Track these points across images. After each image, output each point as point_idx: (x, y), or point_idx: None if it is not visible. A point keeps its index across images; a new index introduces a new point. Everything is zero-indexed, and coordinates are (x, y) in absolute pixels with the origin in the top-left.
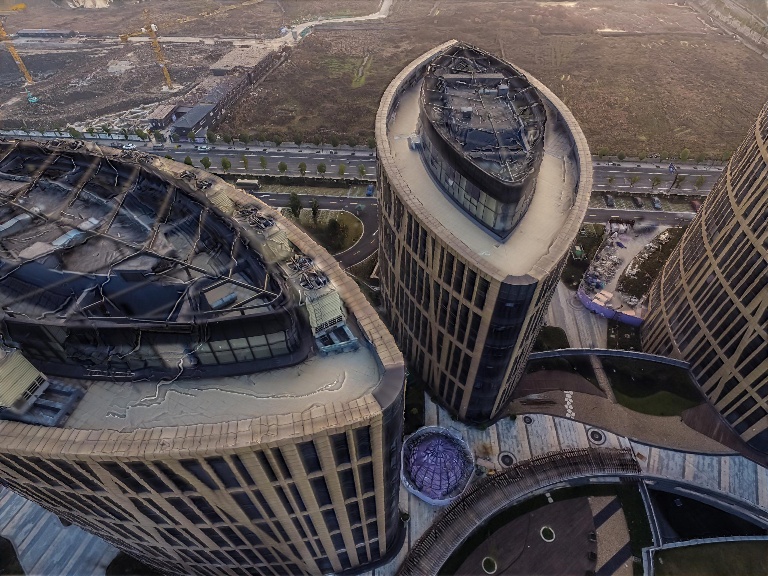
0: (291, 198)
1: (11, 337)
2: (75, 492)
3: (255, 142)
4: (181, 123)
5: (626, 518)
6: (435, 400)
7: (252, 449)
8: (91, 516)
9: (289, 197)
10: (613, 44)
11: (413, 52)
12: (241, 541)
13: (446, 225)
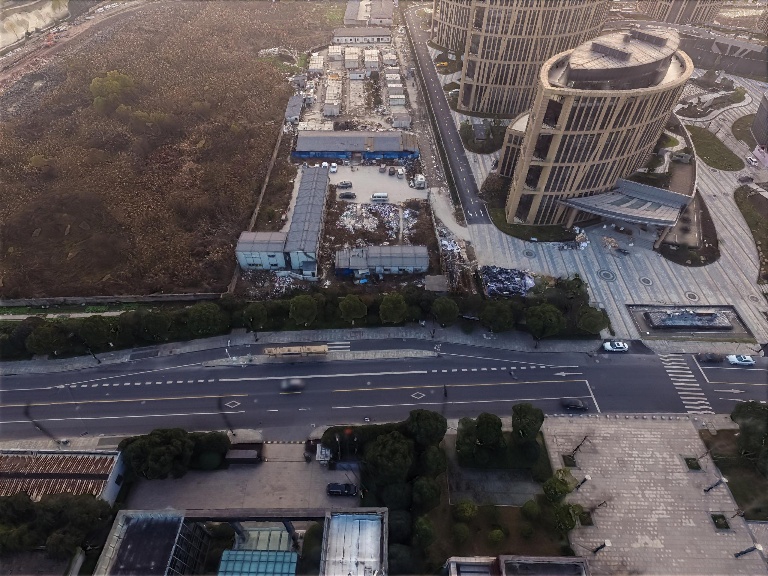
0: None
1: None
2: None
3: None
4: None
5: None
6: None
7: None
8: None
9: None
10: None
11: None
12: None
13: None
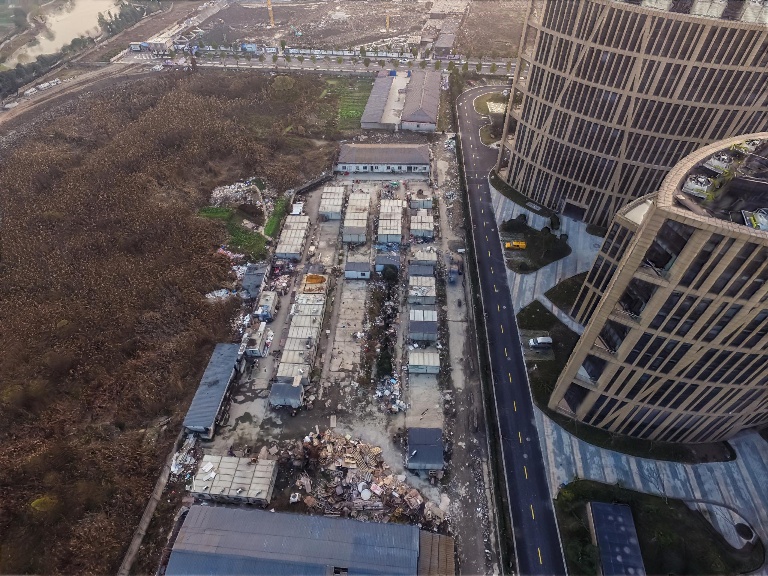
0: None
1: None
2: None
3: (499, 58)
4: (442, 44)
5: None
6: None
7: None
8: (728, 106)
9: None
10: None
11: None
12: None
13: None
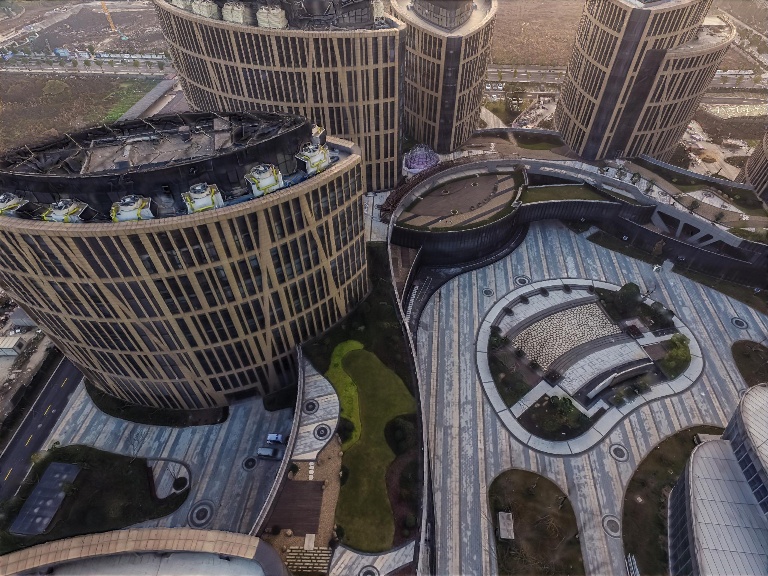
0: None
1: (281, 8)
2: (294, 71)
3: None
4: None
5: (514, 180)
6: None
7: (359, 36)
8: (288, 103)
9: None
10: (566, 3)
11: None
12: (340, 129)
13: None
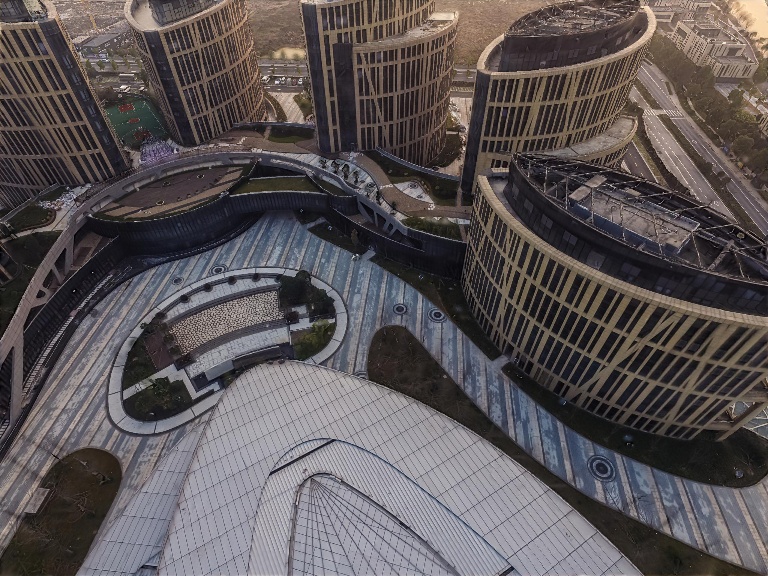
0: (141, 72)
1: None
2: None
3: None
4: (90, 44)
5: None
6: (172, 139)
7: None
8: None
9: (139, 72)
10: None
11: (289, 7)
12: (23, 121)
13: (143, 24)
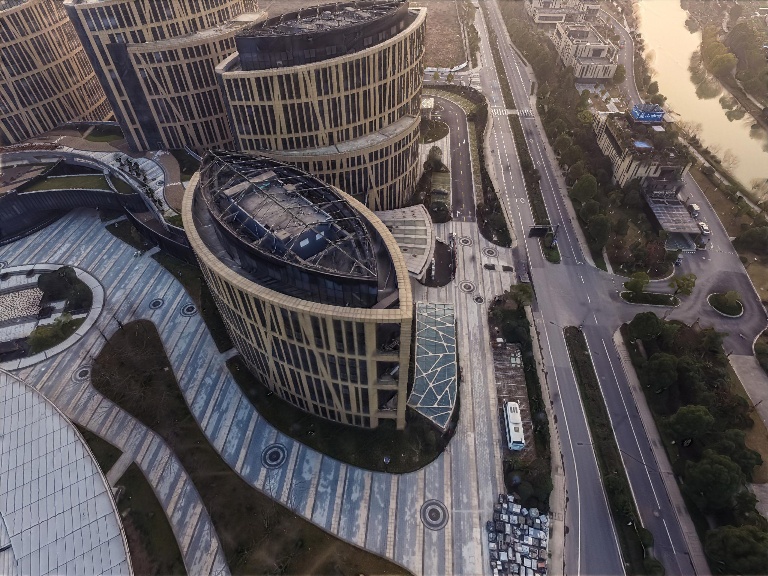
0: None
1: None
2: None
3: None
4: None
5: (43, 170)
6: None
7: None
8: None
9: None
10: None
11: None
12: None
13: None
